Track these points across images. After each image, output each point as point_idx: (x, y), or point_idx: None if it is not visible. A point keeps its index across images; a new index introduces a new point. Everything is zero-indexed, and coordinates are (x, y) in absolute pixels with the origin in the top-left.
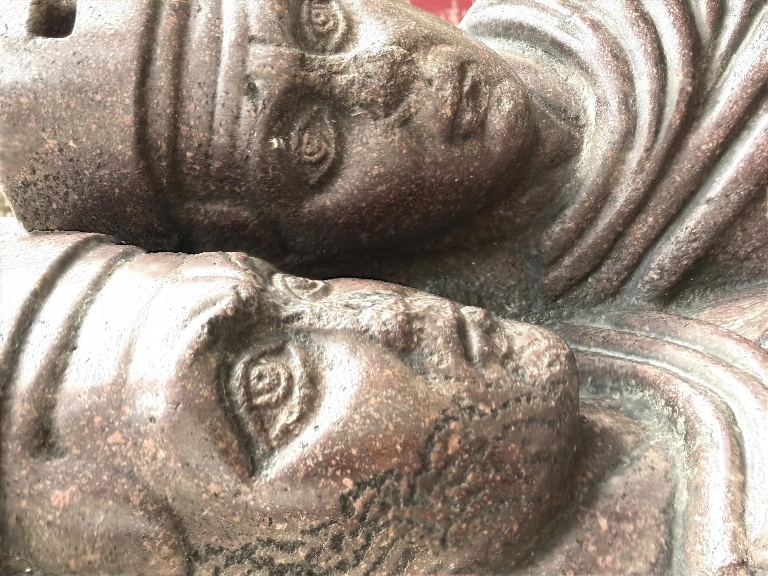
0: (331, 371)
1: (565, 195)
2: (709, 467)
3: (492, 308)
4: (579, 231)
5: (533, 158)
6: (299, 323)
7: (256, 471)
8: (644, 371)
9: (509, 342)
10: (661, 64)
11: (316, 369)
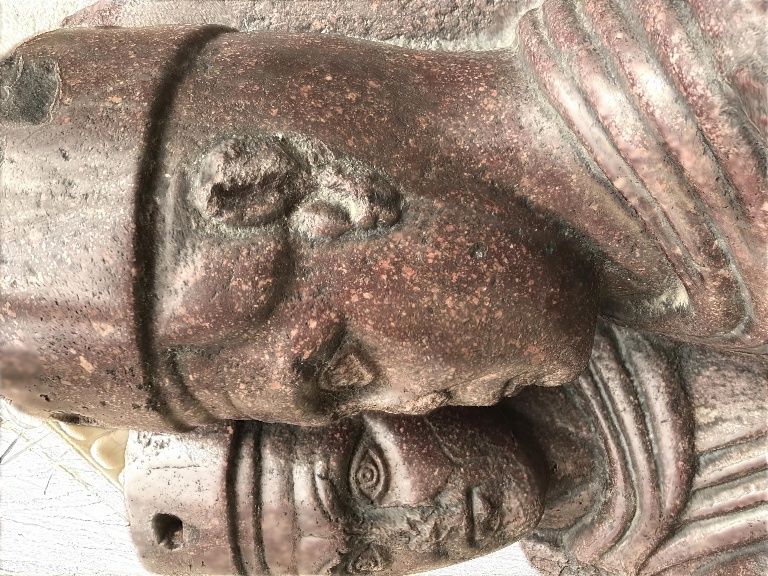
0: (396, 555)
1: (622, 308)
2: (601, 534)
3: None
4: None
5: None
6: (375, 543)
7: (367, 573)
8: (610, 449)
9: (501, 520)
10: None
11: (388, 554)
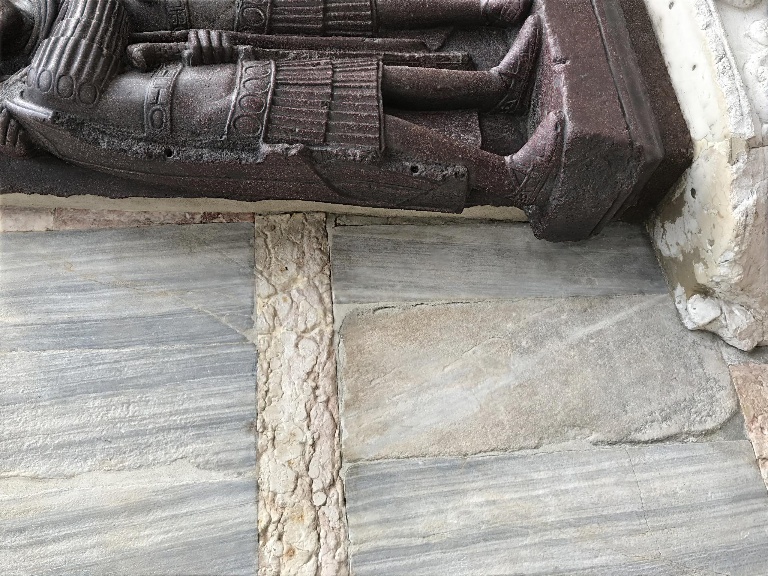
0: None
1: None
2: None
3: (17, 68)
4: (33, 46)
5: (22, 28)
6: None
7: None
8: None
9: None
10: (46, 5)
11: None
